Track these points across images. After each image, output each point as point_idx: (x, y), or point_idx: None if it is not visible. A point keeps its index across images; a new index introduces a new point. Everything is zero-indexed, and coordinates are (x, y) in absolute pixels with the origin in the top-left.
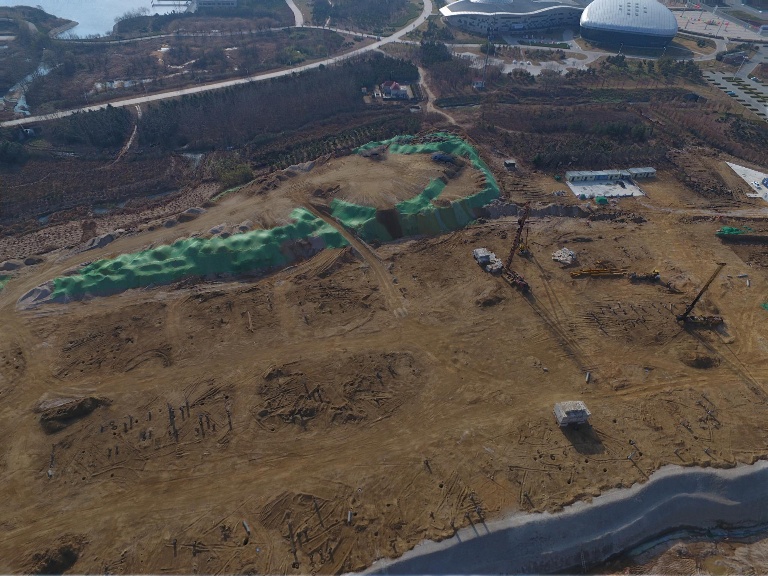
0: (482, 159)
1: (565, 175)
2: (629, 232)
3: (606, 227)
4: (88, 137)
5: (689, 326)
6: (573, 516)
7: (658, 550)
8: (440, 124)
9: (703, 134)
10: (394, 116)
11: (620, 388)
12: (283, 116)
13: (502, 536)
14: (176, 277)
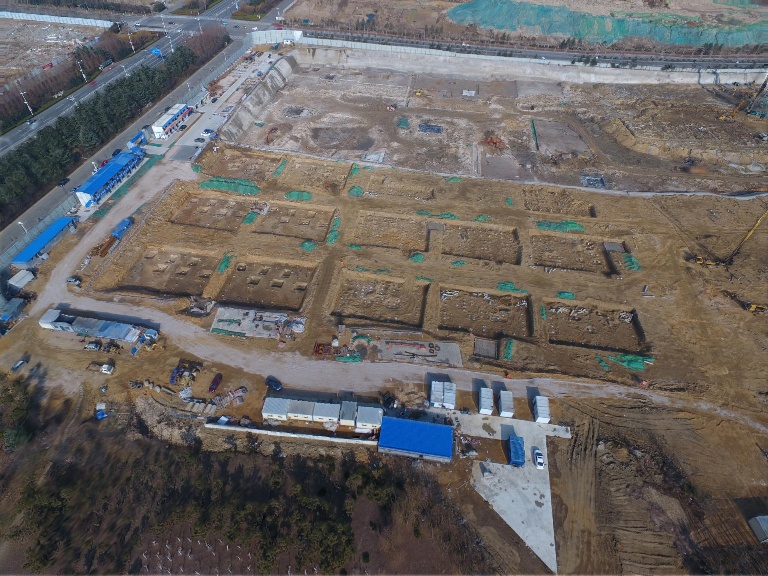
0: None
1: None
2: None
3: None
4: None
5: None
6: None
7: (736, 193)
8: None
9: None
10: None
11: None
12: None
13: None
14: None
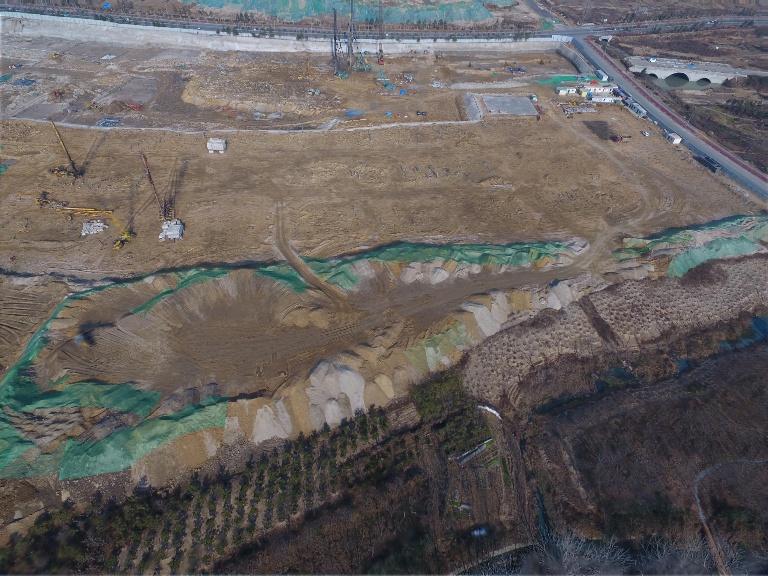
0: None
1: None
2: None
3: None
4: None
5: None
6: None
7: None
8: None
9: None
10: None
11: None
12: None
13: None
14: None
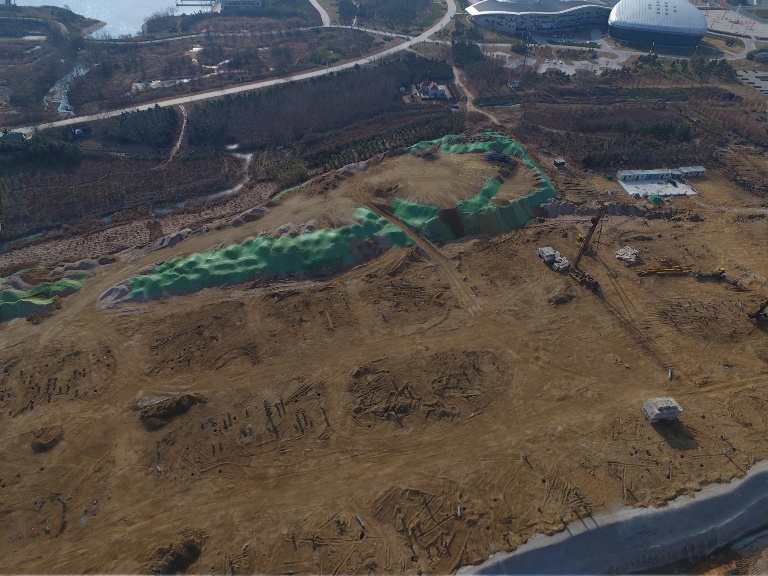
0: (532, 158)
1: (616, 174)
2: (688, 231)
3: (664, 226)
4: (139, 137)
5: (762, 324)
6: (678, 510)
7: (760, 544)
8: (483, 123)
9: (746, 133)
10: (437, 116)
11: (703, 385)
12: (327, 116)
13: (611, 530)
14: (250, 276)
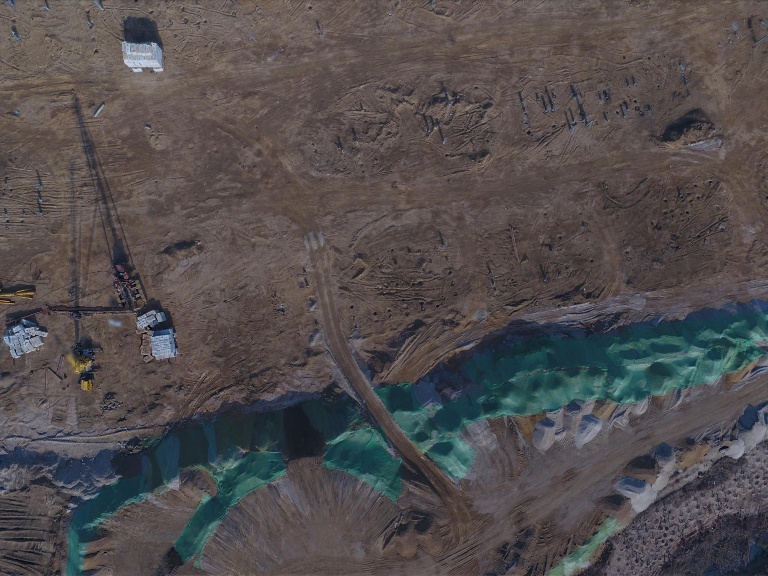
0: None
1: None
2: None
3: None
4: None
5: None
6: None
7: None
8: None
9: None
10: None
11: (66, 92)
12: None
13: None
14: (627, 333)
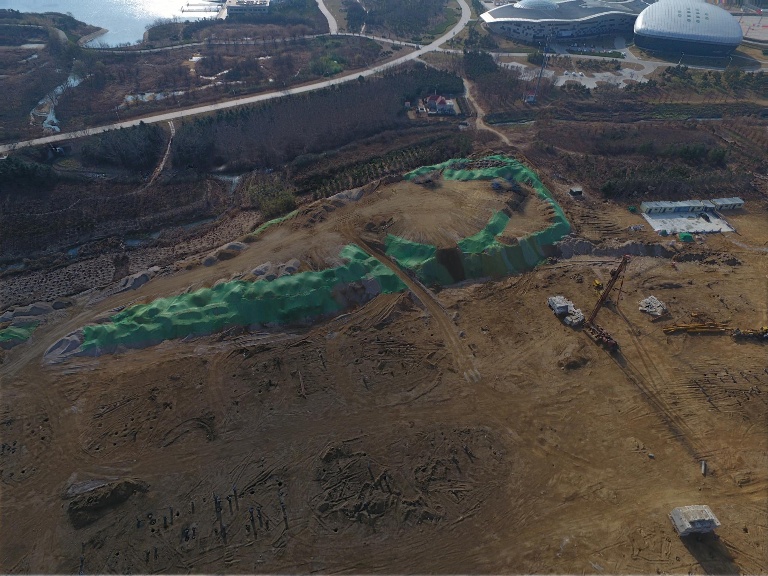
0: (545, 186)
1: (640, 206)
2: (723, 277)
3: (695, 270)
4: (120, 158)
5: None
6: None
7: None
8: (493, 144)
9: None
10: (443, 135)
11: (745, 484)
12: (323, 134)
13: None
14: (217, 327)
